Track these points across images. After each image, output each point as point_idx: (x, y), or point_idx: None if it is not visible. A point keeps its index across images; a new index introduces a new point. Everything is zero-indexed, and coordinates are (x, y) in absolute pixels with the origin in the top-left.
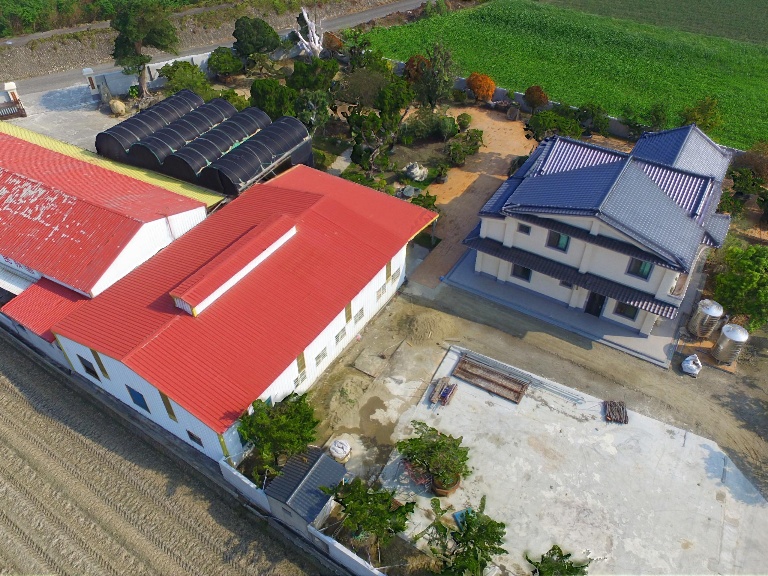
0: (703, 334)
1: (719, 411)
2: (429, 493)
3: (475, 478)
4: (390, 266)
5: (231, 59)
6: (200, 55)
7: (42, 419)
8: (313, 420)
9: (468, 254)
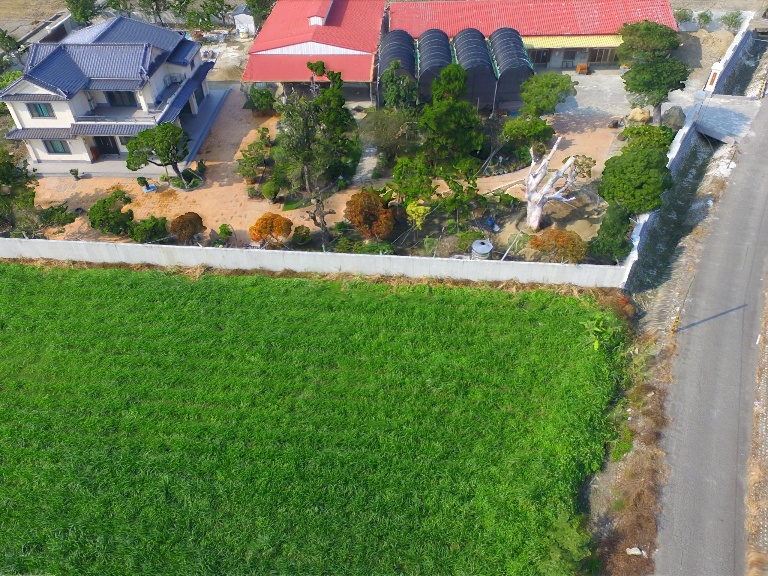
0: None
1: None
2: None
3: None
4: None
5: None
6: None
7: None
8: (247, 1)
9: (219, 103)
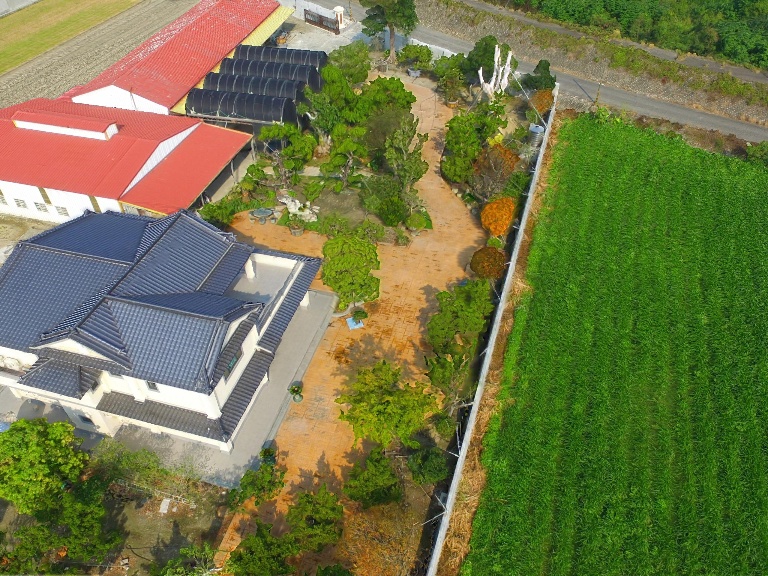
0: None
1: None
2: None
3: None
4: (98, 203)
5: (453, 66)
6: (451, 52)
7: None
8: None
9: None
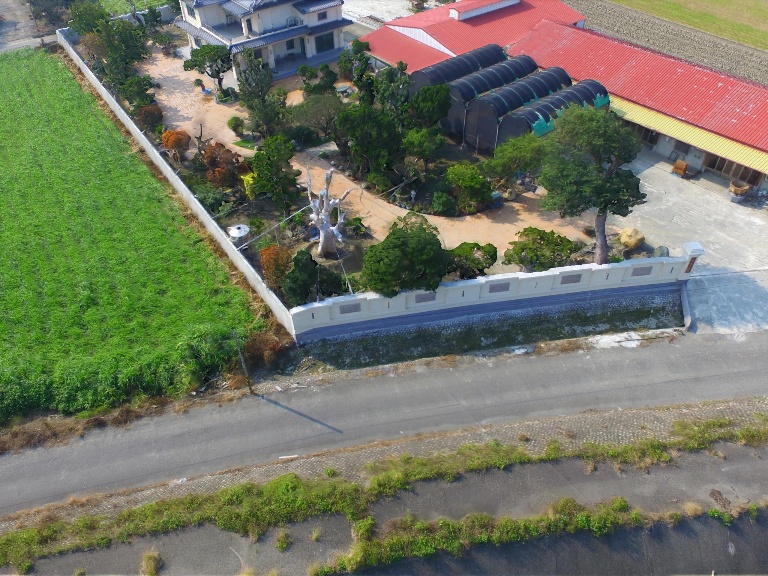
0: None
1: None
2: None
3: (405, 7)
4: None
5: (458, 251)
6: (511, 274)
7: None
8: None
9: None
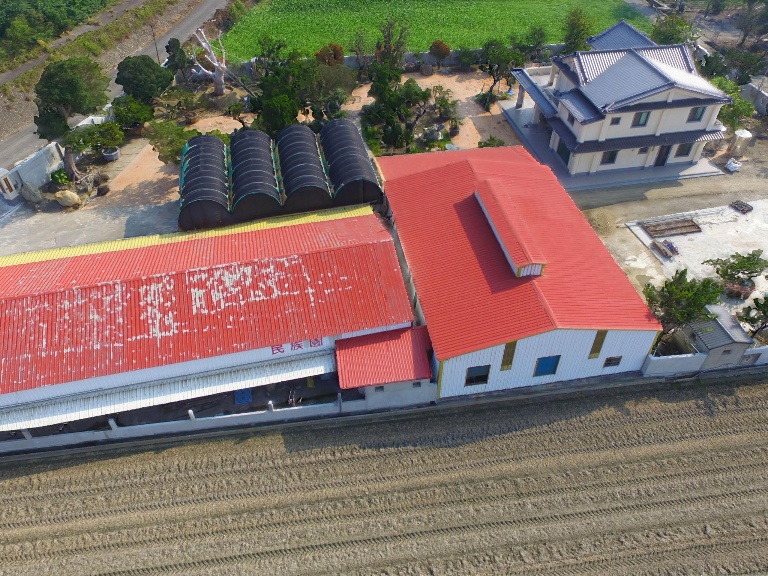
0: (717, 147)
1: None
2: (741, 300)
3: None
4: None
5: (140, 106)
6: None
7: (468, 448)
8: None
9: None
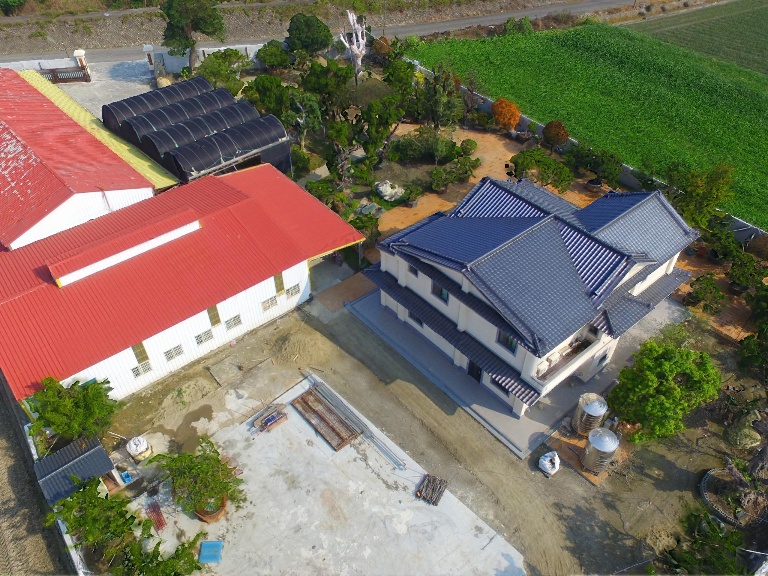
0: (582, 431)
1: (551, 523)
2: (194, 514)
3: (246, 513)
4: (282, 280)
5: (279, 53)
6: (254, 45)
7: None
8: (95, 410)
9: None
